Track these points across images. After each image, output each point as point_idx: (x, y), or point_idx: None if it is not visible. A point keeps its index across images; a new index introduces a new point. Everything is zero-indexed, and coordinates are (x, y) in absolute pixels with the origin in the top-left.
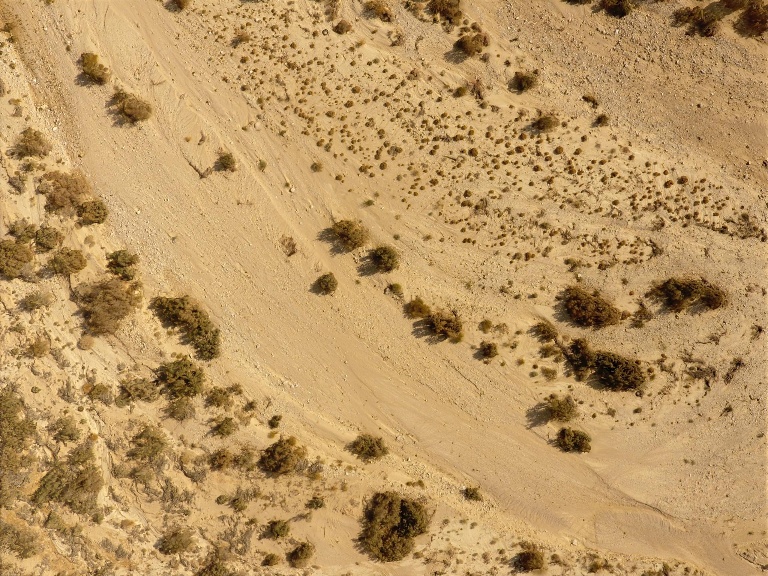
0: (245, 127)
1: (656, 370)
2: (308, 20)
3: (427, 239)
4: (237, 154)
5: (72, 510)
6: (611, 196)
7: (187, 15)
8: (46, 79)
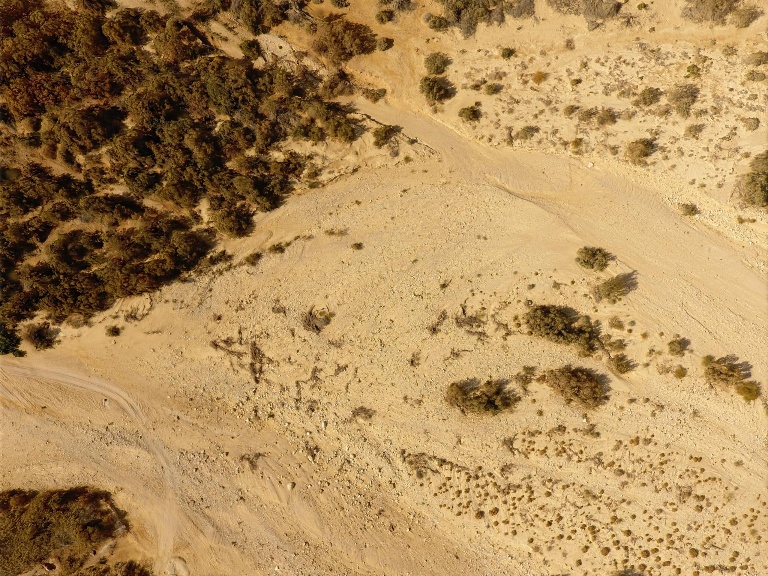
0: None
1: (512, 325)
2: None
3: (739, 462)
4: None
5: None
6: (553, 501)
7: None
8: None
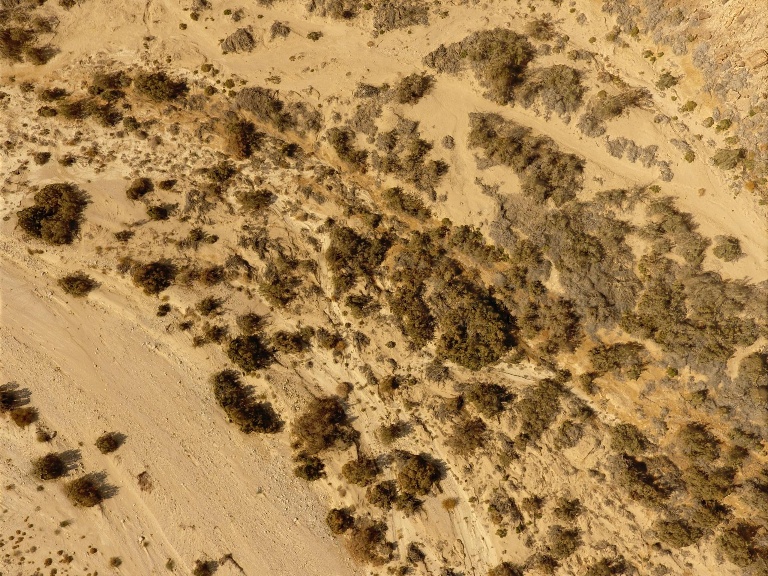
0: None
1: None
2: None
3: (11, 486)
4: None
5: None
6: None
7: None
8: None
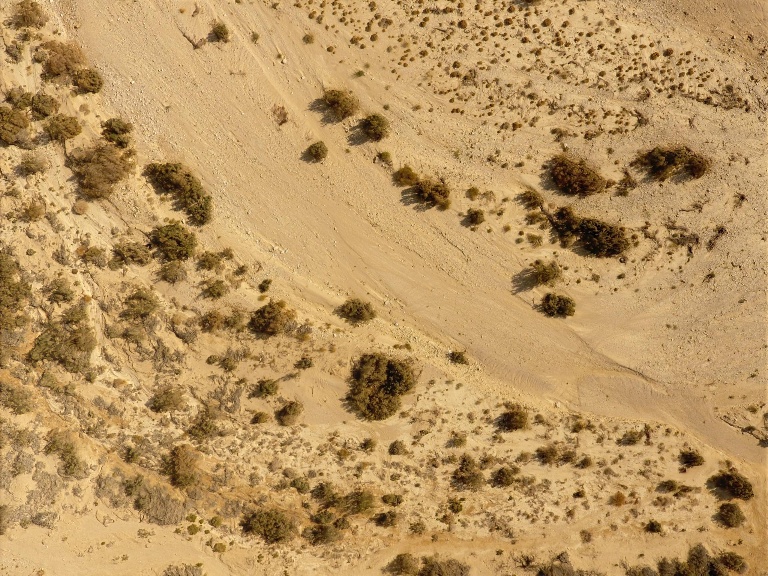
0: None
1: (640, 237)
2: None
3: (416, 109)
4: (230, 26)
5: (65, 367)
6: (598, 67)
7: None
8: None
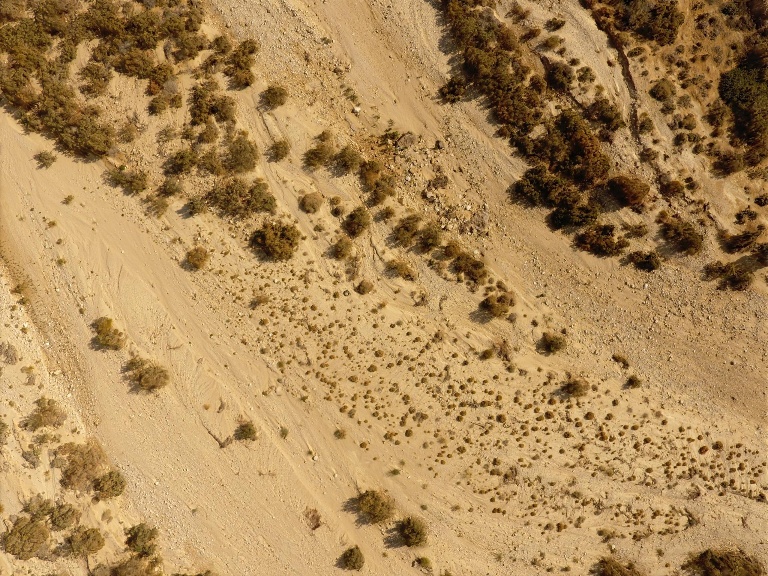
0: (265, 393)
1: None
2: (328, 280)
3: (455, 509)
4: (258, 421)
5: None
6: (644, 464)
7: (203, 275)
8: (59, 342)
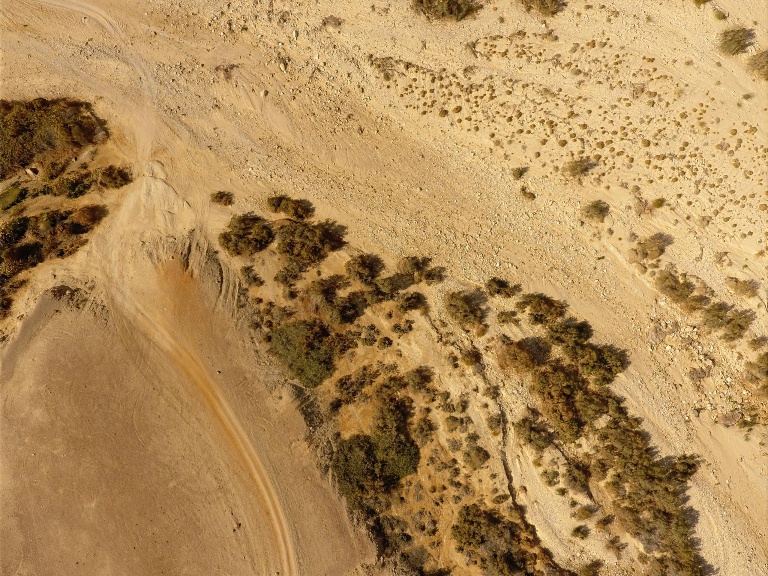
0: None
1: None
2: None
3: (689, 62)
4: None
5: None
6: (513, 99)
7: None
8: None
